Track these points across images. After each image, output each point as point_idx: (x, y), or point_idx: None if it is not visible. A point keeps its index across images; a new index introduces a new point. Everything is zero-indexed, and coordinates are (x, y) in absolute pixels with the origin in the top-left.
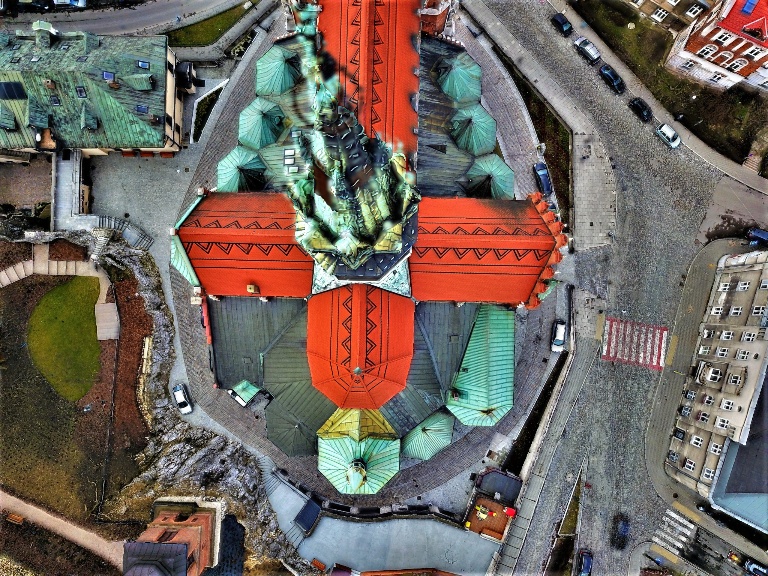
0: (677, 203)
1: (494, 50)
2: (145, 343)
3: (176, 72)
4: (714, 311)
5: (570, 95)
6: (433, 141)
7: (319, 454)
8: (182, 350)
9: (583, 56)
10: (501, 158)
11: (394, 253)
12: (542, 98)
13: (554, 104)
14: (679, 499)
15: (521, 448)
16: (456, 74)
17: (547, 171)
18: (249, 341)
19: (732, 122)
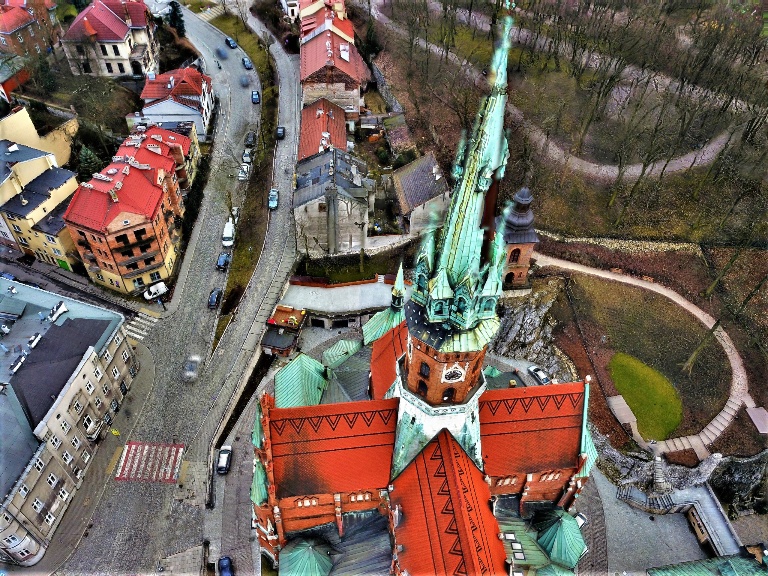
0: None
1: None
2: None
3: None
4: (65, 496)
5: None
6: None
7: None
8: None
9: None
10: None
11: None
12: None
13: None
14: None
15: (260, 372)
16: None
17: None
18: None
19: None
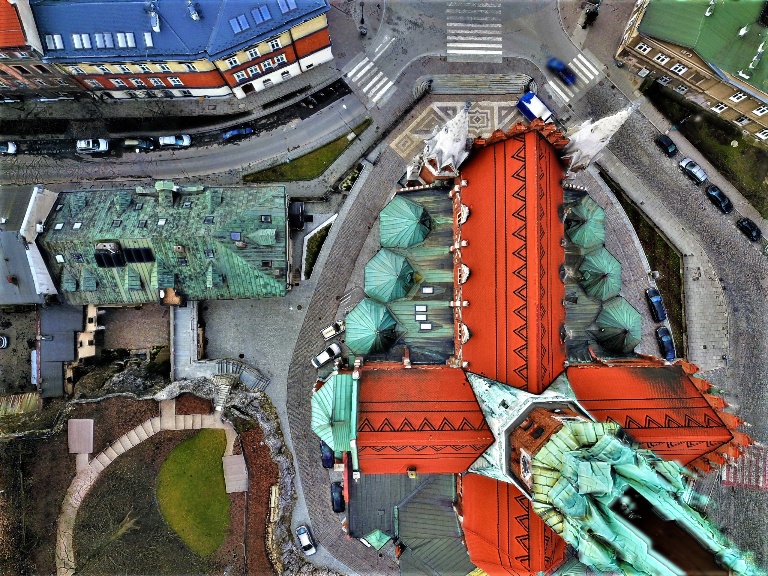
0: None
1: (601, 175)
2: (272, 491)
3: (289, 214)
4: None
5: (677, 216)
6: None
7: None
8: (303, 490)
9: (688, 177)
10: (627, 301)
11: None
12: (651, 223)
13: (661, 226)
14: None
15: None
16: (587, 227)
17: (660, 297)
18: (385, 496)
19: None
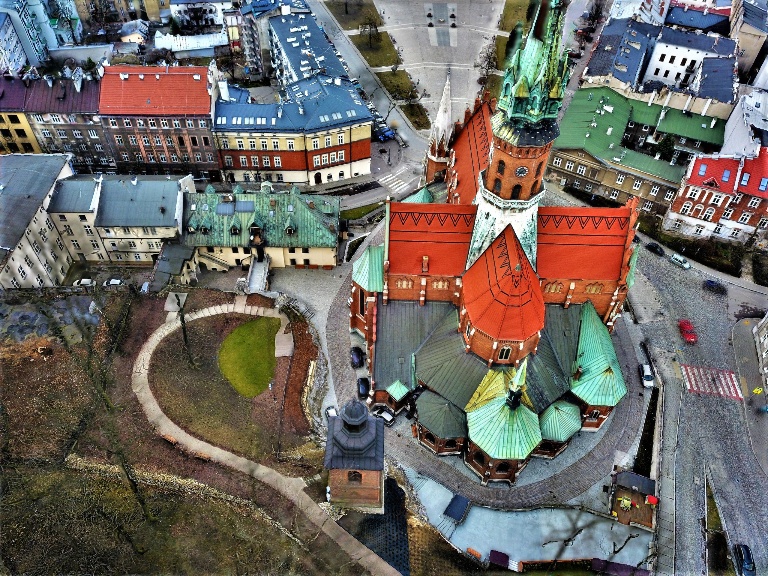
0: (703, 298)
1: None
2: (311, 364)
3: (340, 221)
4: (765, 355)
5: None
6: None
7: (469, 425)
8: (334, 384)
9: None
10: None
11: (554, 118)
12: None
13: None
14: None
15: (643, 463)
16: None
17: None
18: (404, 342)
19: (721, 255)
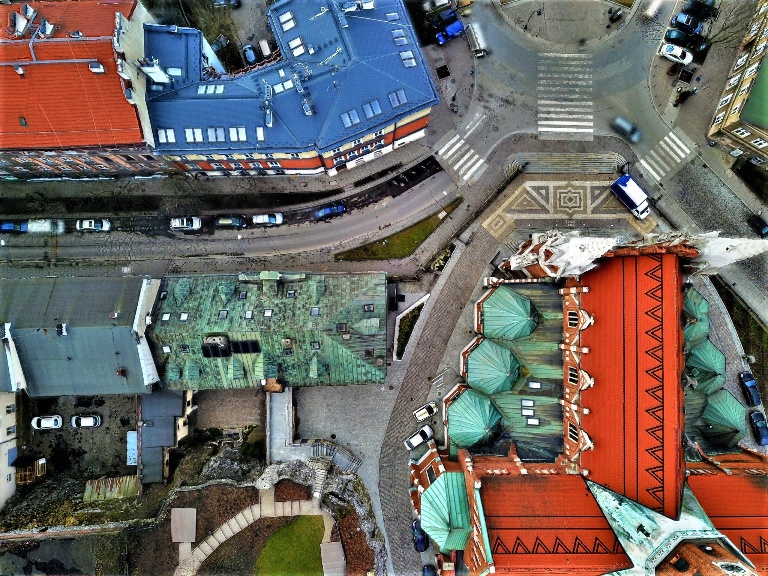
0: None
1: None
2: None
3: None
4: None
5: None
6: None
7: None
8: (395, 573)
9: None
10: (731, 394)
11: None
12: (746, 306)
13: (754, 308)
14: None
15: None
16: (697, 324)
17: (755, 382)
18: None
19: None
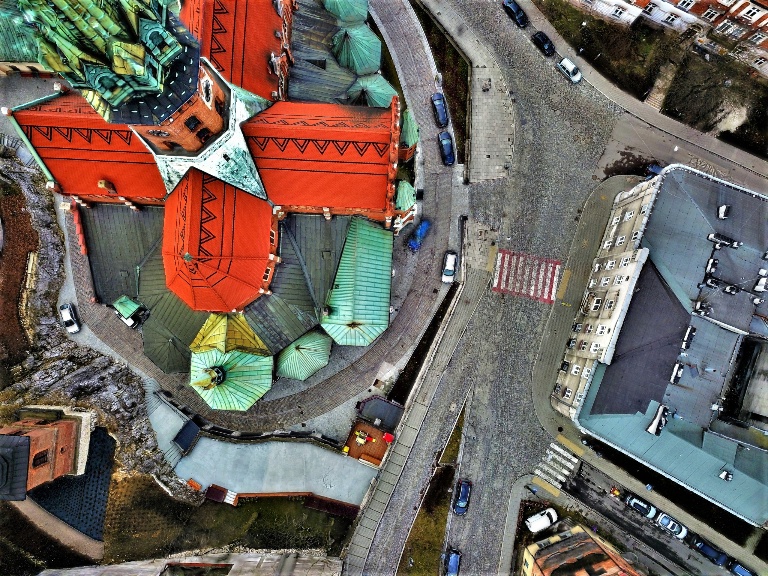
0: (576, 138)
1: None
2: (30, 258)
3: None
4: (606, 245)
5: (472, 28)
6: (312, 56)
7: (191, 369)
8: (72, 270)
9: None
10: (385, 79)
11: (155, 91)
12: (442, 29)
13: (456, 37)
14: (564, 433)
15: (408, 378)
16: None
17: (443, 101)
18: (124, 253)
19: (634, 58)
